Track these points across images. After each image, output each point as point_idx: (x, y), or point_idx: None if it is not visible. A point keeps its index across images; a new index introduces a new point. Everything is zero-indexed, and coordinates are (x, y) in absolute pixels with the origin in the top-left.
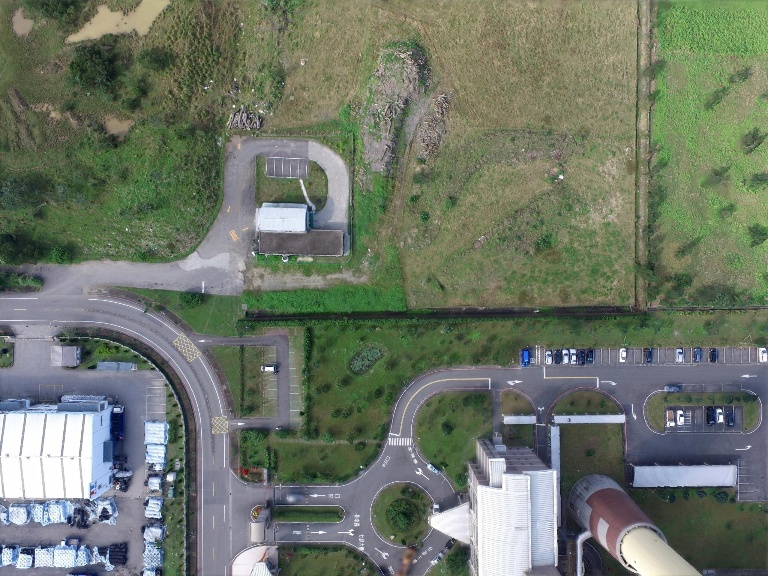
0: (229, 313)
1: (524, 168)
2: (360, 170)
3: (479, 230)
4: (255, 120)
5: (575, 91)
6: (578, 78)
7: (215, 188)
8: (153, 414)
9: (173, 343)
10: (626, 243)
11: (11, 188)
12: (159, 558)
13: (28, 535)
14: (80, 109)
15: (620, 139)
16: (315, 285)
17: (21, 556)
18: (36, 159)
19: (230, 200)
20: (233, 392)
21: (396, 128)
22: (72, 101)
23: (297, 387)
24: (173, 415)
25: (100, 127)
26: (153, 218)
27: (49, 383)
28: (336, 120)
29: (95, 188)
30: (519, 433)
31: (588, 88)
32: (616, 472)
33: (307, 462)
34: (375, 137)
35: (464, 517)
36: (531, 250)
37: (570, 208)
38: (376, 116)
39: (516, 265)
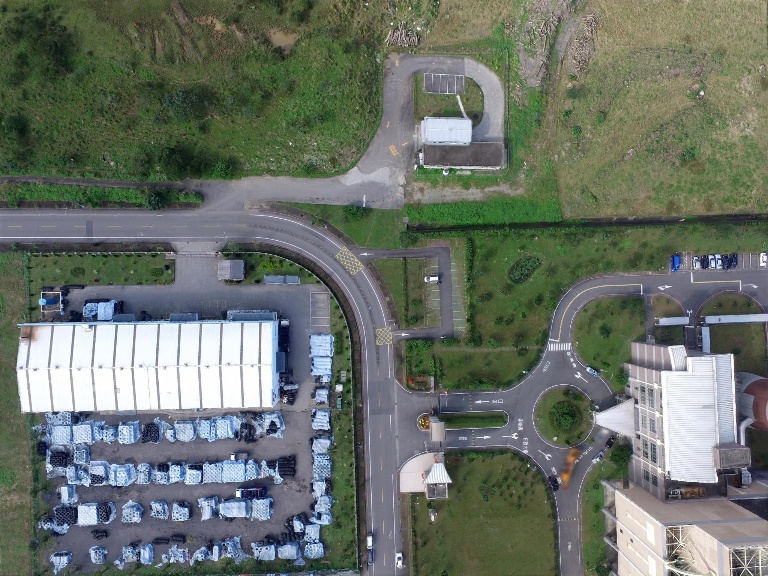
0: (390, 226)
1: (668, 84)
2: (516, 86)
3: (628, 143)
4: (413, 37)
5: (712, 12)
6: (715, 0)
7: (375, 103)
8: (318, 327)
9: (336, 257)
10: (762, 155)
11: (183, 98)
12: (329, 468)
13: (194, 452)
14: (245, 22)
15: (754, 57)
16: (474, 198)
17: (190, 472)
18: (202, 72)
19: (389, 116)
20: (396, 303)
21: (550, 45)
22: (237, 14)
23: (459, 297)
24: (338, 327)
25: (266, 40)
26: (318, 131)
27: (212, 299)
28: (490, 38)
29: (263, 100)
30: (670, 335)
31: (724, 10)
32: (760, 369)
33: (471, 369)
34: (530, 53)
35: (629, 412)
36: (677, 161)
37: (711, 122)
38: (531, 33)
39: (663, 176)
